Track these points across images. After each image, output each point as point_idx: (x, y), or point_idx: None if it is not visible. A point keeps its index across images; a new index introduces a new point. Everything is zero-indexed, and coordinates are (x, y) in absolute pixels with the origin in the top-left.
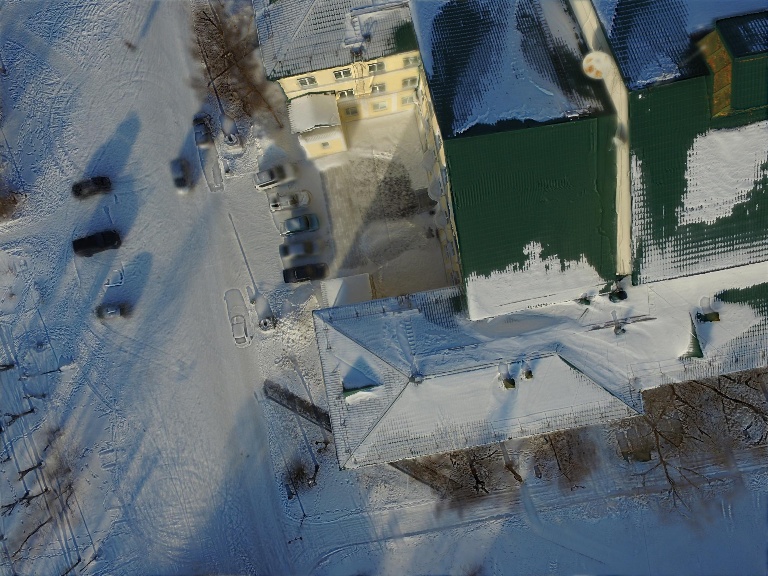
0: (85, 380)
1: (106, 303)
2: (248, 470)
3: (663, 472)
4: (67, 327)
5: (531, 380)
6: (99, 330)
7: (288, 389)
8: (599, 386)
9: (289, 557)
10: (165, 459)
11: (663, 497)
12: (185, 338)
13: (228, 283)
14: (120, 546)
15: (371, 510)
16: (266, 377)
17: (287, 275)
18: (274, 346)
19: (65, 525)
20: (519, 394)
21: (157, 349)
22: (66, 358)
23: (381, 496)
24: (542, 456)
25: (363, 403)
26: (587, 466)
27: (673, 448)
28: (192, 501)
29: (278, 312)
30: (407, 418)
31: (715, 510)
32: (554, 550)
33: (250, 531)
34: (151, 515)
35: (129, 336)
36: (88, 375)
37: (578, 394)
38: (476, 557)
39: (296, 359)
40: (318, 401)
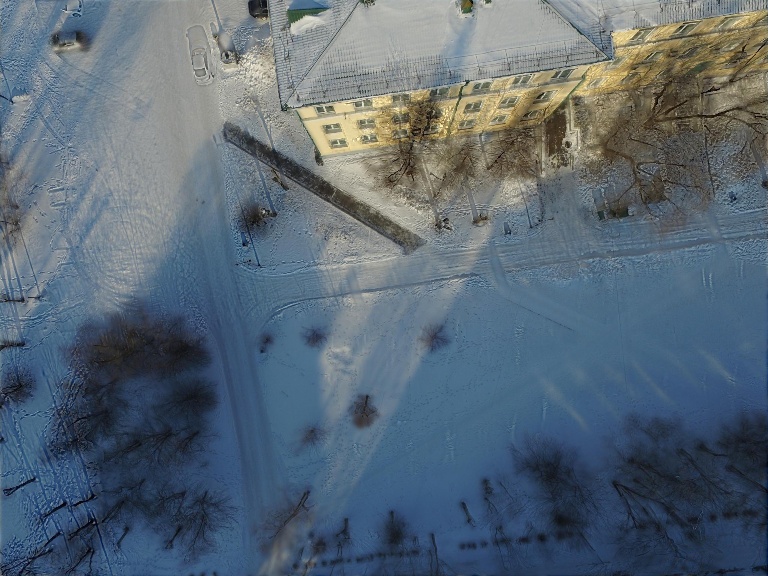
0: (38, 114)
1: (63, 35)
2: (203, 217)
3: (641, 235)
4: (22, 58)
5: (491, 7)
6: (55, 63)
7: (248, 132)
8: (566, 21)
9: (241, 310)
10: (117, 201)
11: (640, 261)
12: (144, 75)
13: (191, 19)
14: (65, 289)
15: (329, 263)
16: (226, 119)
17: (252, 5)
18: (236, 85)
19: (10, 264)
20: (478, 24)
21: (114, 85)
22: (19, 90)
23: (340, 248)
24: (512, 211)
25: (309, 32)
26: (560, 226)
27: (653, 210)
28: (143, 247)
29: (242, 49)
30: (355, 48)
31: (695, 278)
32: (521, 314)
33: (202, 281)
34: (99, 259)
35: (86, 70)
36: (41, 109)
37: (542, 30)
38: (438, 318)
39: (258, 100)
40: (279, 146)
